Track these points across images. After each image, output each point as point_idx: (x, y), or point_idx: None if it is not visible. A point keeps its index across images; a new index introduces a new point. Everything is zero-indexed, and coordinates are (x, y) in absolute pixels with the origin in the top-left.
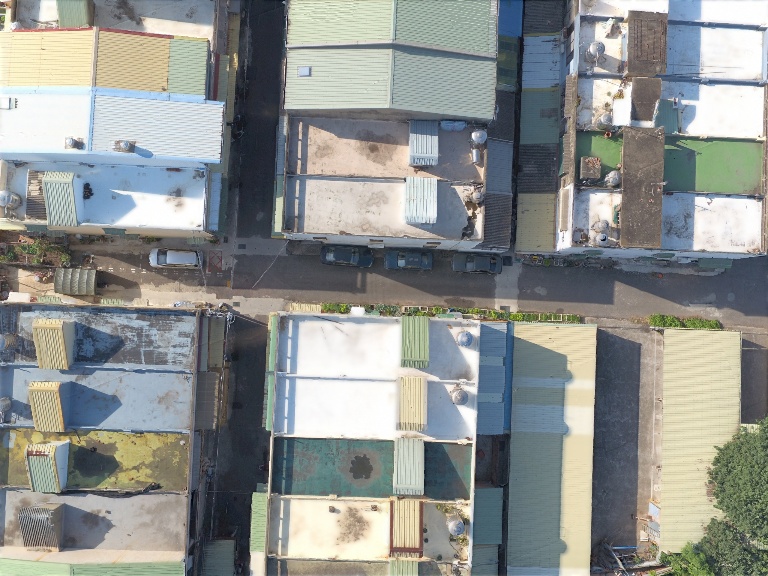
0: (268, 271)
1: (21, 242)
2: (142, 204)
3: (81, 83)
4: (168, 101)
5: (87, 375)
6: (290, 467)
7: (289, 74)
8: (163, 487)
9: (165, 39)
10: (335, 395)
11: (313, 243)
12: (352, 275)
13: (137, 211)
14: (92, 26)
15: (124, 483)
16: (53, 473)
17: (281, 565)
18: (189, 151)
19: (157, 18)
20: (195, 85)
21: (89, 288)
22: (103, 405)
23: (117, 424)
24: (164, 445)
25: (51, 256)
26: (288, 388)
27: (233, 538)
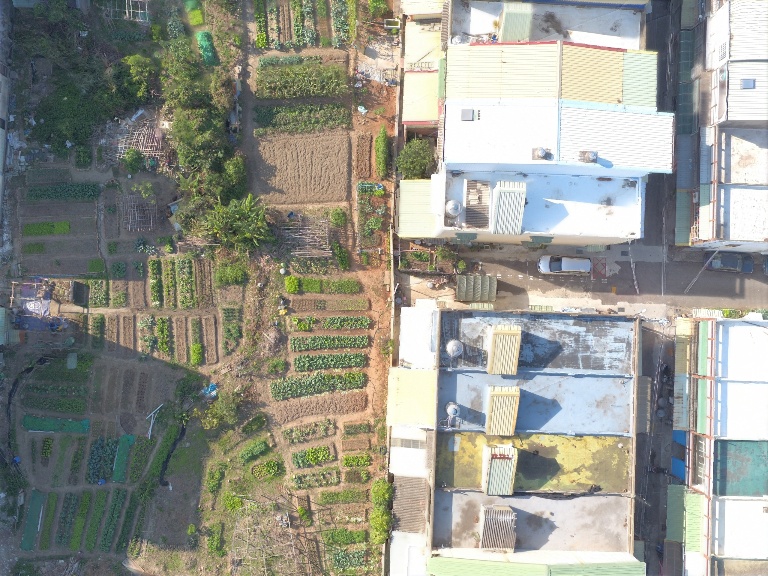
0: (651, 277)
1: (413, 250)
2: (574, 213)
3: (546, 95)
4: (624, 113)
5: (527, 380)
6: (724, 469)
7: (732, 86)
8: (603, 489)
9: (619, 52)
10: (765, 398)
11: (693, 250)
12: (731, 281)
13: (570, 219)
14: (555, 40)
15: (566, 485)
16: (511, 476)
17: (718, 565)
18: (645, 161)
19: (584, 31)
20: (647, 97)
21: (491, 294)
22: (544, 409)
23: (558, 428)
24: (603, 448)
25: (442, 263)
26: (720, 392)
27: (643, 539)
